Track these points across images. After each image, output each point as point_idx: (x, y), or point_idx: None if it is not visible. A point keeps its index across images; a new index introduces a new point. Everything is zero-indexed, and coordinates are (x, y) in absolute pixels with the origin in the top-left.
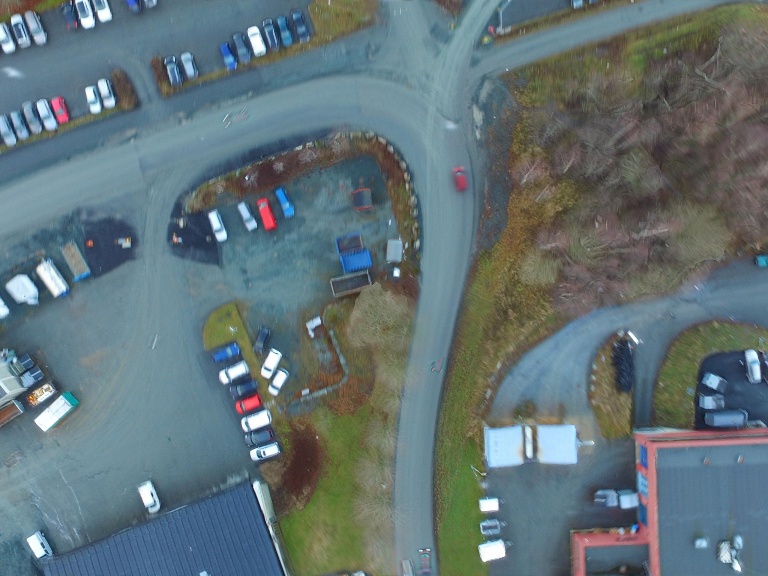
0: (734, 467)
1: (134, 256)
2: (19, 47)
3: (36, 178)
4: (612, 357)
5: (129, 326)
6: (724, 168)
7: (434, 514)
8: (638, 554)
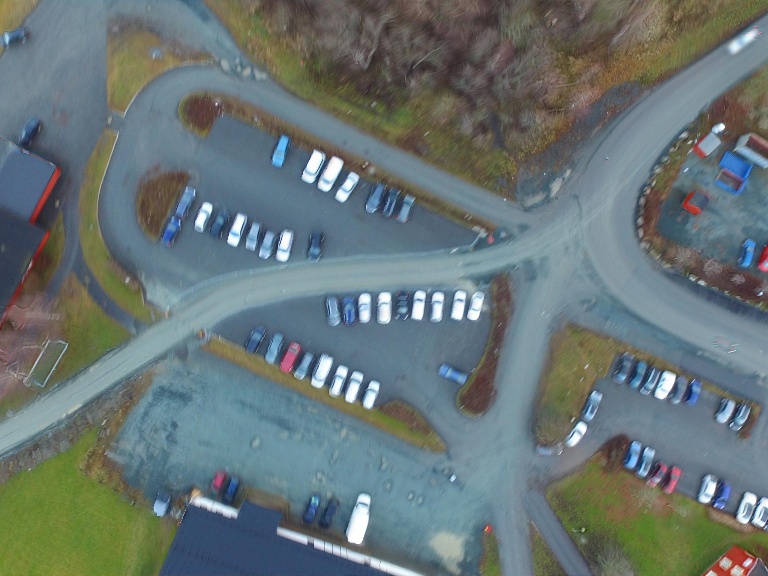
0: None
1: None
2: None
3: None
4: None
5: None
6: None
7: None
8: None
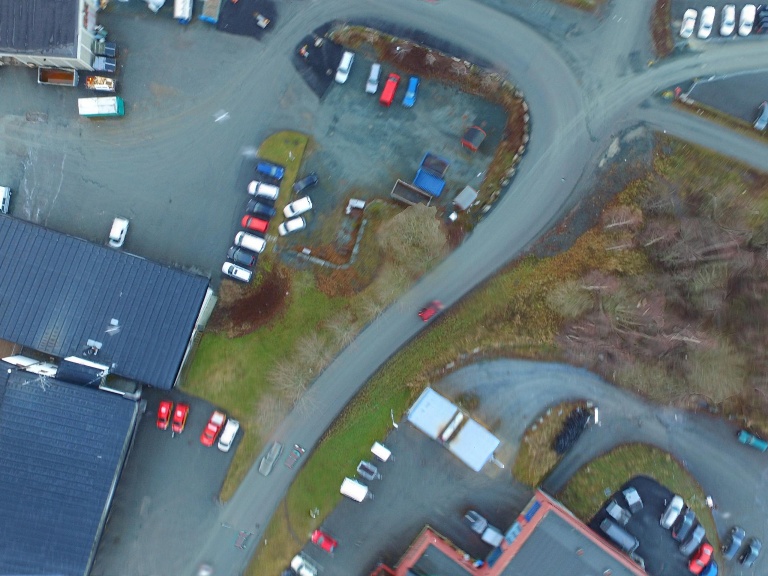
0: (598, 574)
1: (261, 37)
2: None
3: None
4: (568, 417)
5: (212, 88)
6: None
7: (330, 426)
8: None
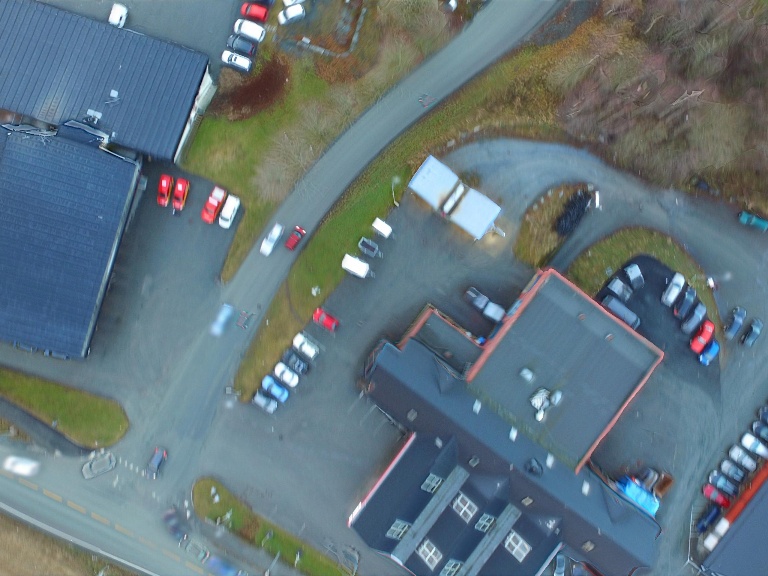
0: (600, 340)
1: None
2: None
3: None
4: (569, 199)
5: None
6: None
7: (331, 208)
8: (469, 352)
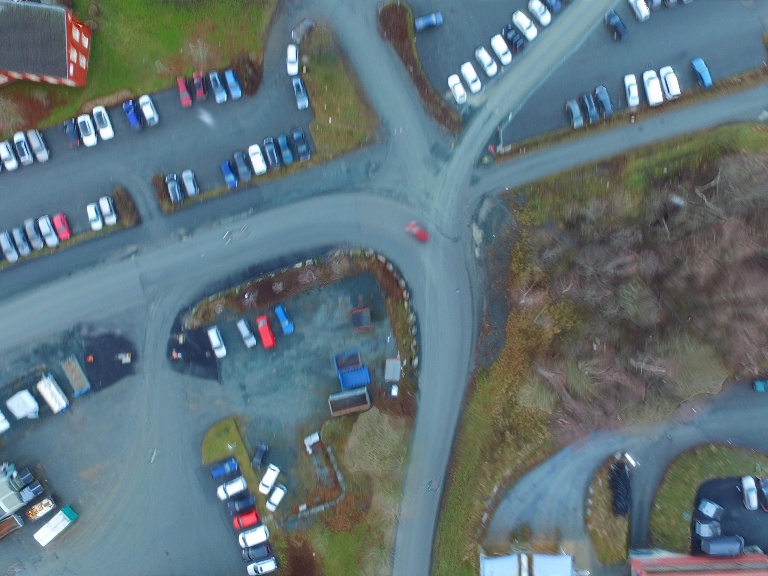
0: None
1: (134, 371)
2: (22, 164)
3: (37, 293)
4: (609, 480)
5: (128, 440)
6: (722, 310)
7: None
8: None
